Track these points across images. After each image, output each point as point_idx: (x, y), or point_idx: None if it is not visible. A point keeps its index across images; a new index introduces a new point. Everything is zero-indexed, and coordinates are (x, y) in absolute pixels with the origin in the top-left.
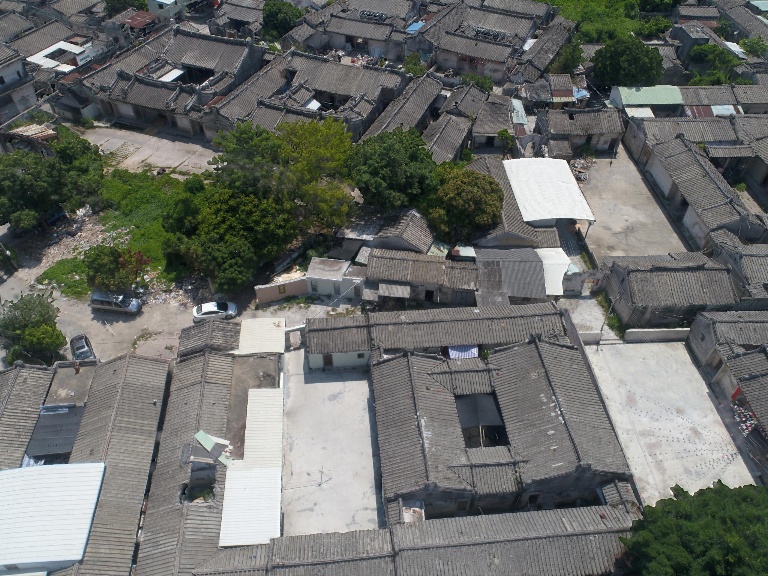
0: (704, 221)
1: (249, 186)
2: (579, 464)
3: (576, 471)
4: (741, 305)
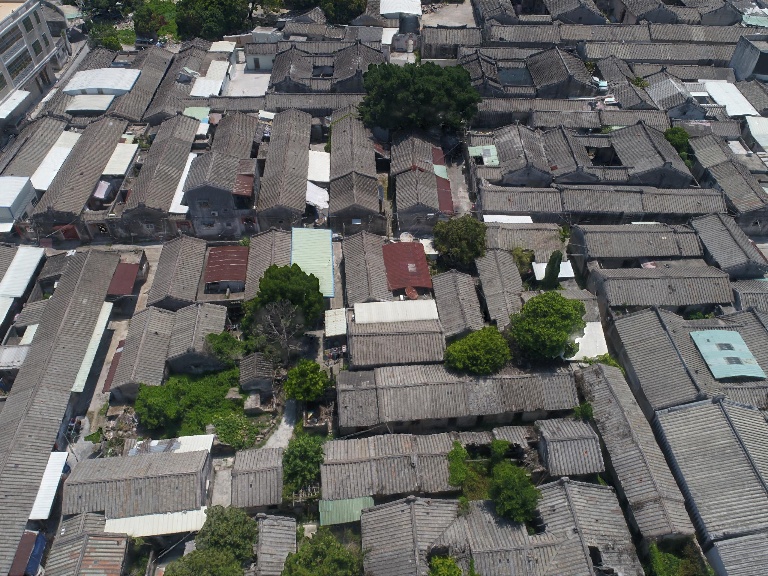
0: None
1: None
2: (356, 70)
3: (356, 75)
4: (484, 46)
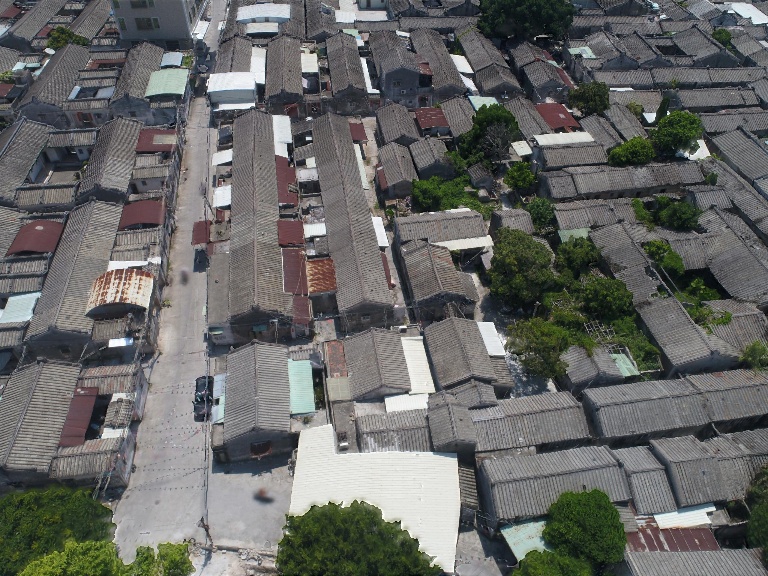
0: None
1: None
2: None
3: (465, 3)
4: None
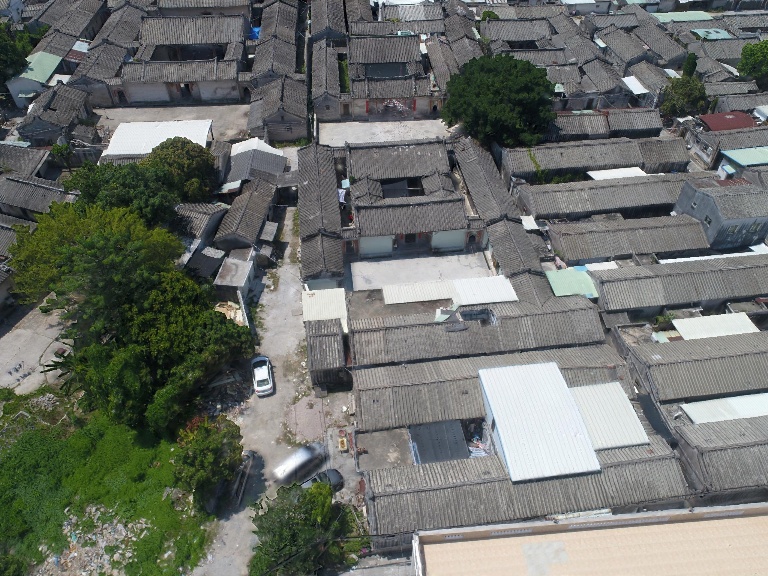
0: (227, 79)
1: (143, 283)
2: (445, 140)
3: None
4: None
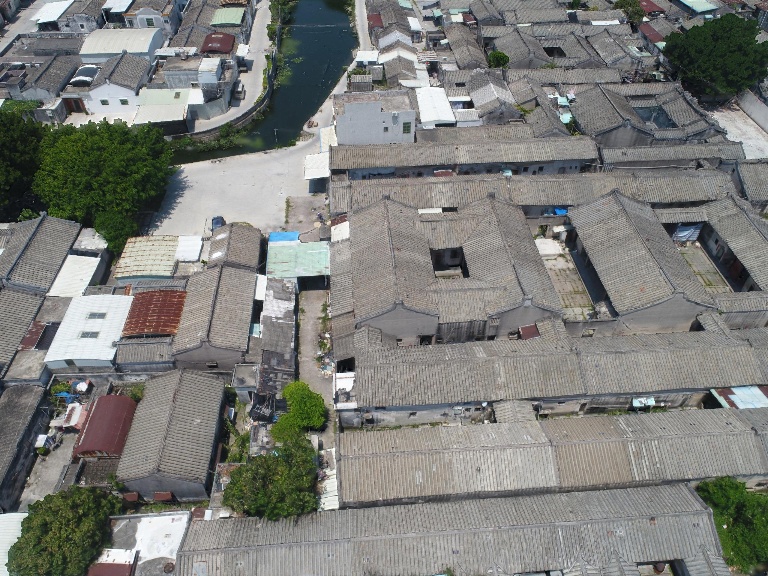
0: None
1: None
2: None
3: None
4: (716, 163)
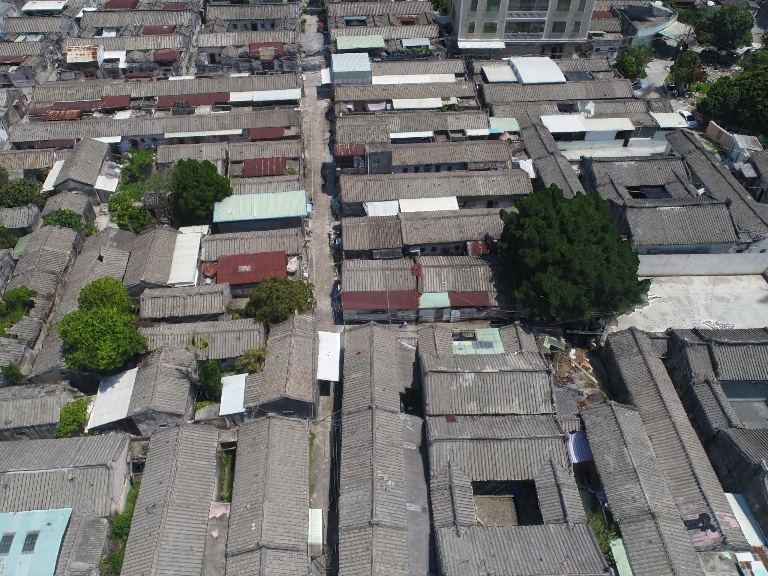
0: None
1: None
2: None
3: None
4: None
